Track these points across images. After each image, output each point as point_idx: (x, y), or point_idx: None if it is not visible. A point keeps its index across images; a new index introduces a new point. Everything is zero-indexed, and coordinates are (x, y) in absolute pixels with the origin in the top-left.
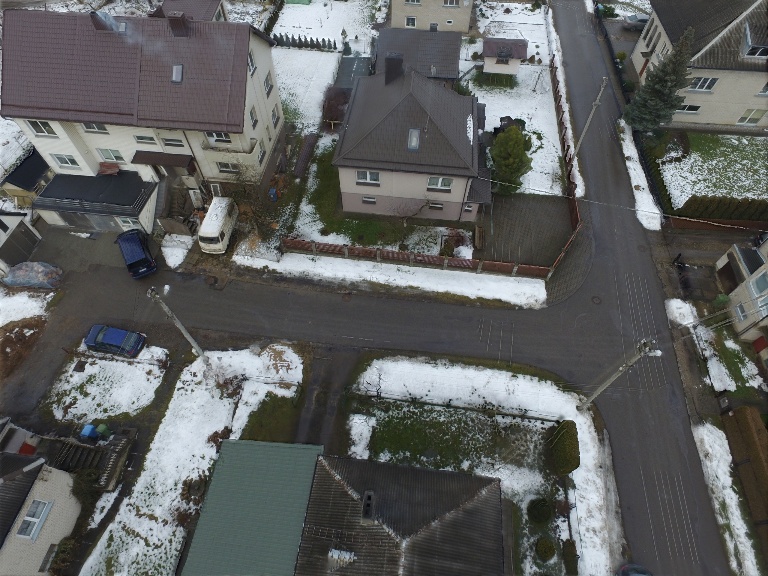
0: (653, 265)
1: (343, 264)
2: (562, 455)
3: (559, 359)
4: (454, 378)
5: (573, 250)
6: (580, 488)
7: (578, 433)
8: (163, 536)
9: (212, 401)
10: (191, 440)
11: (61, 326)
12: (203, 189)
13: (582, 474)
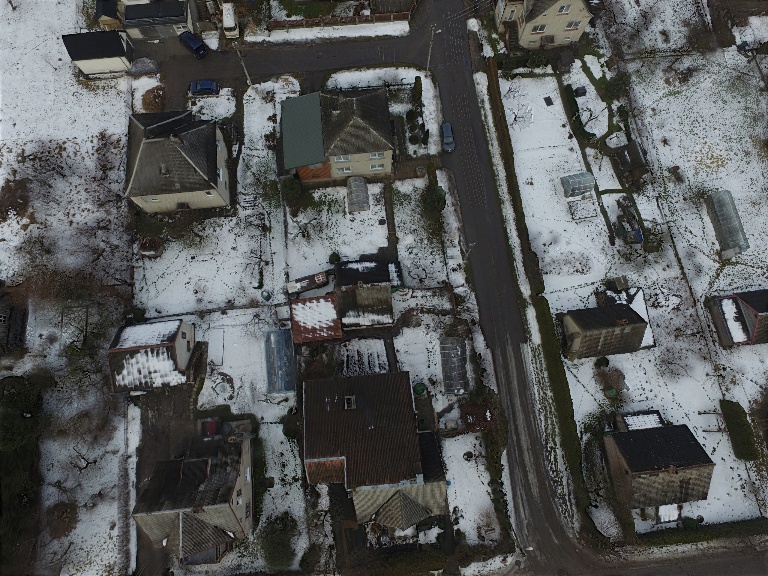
0: (462, 3)
1: (304, 31)
2: (416, 90)
3: (416, 57)
4: (370, 75)
5: (422, 2)
6: (427, 106)
7: (425, 86)
8: (264, 154)
9: (263, 105)
10: (260, 121)
11: (173, 88)
12: (212, 1)
13: (427, 101)
